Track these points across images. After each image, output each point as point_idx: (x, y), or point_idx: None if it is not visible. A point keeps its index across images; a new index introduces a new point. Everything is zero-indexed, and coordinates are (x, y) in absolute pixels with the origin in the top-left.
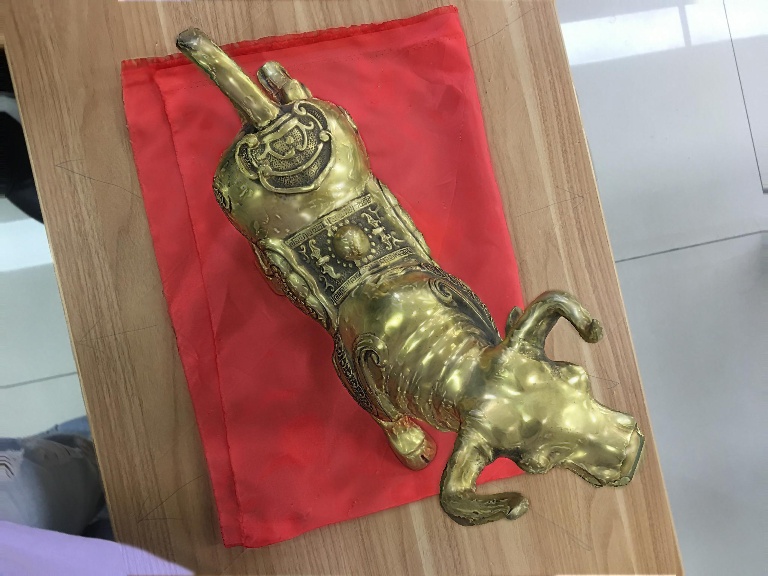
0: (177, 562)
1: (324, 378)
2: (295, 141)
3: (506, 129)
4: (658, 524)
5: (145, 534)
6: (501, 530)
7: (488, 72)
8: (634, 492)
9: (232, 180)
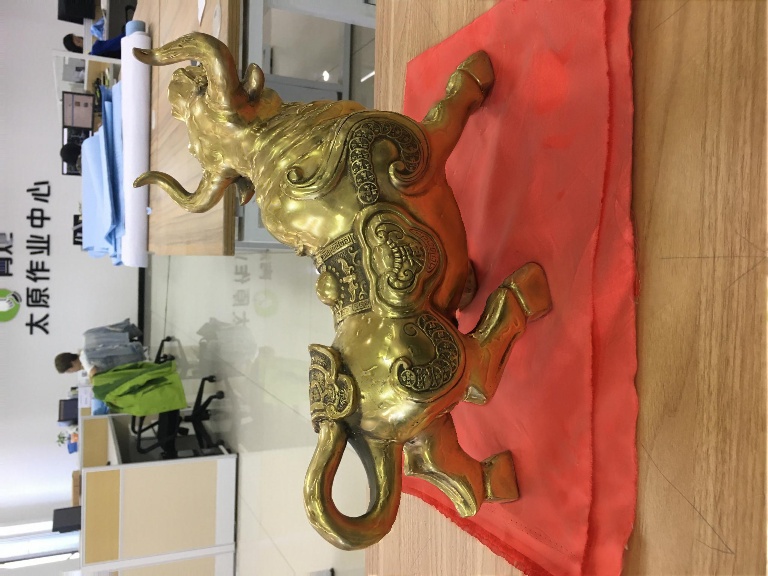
0: None
1: (525, 159)
2: None
3: None
4: (381, 13)
5: None
6: None
7: None
8: (386, 39)
9: (377, 386)
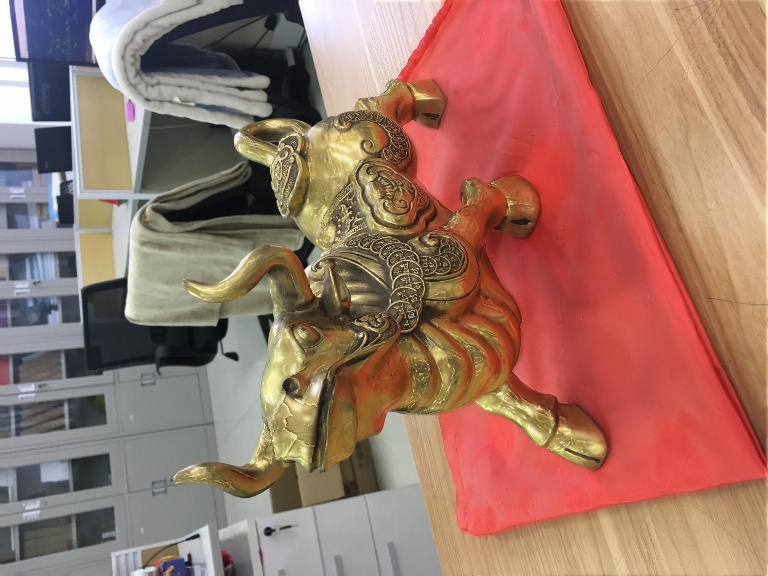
0: (456, 539)
1: None
2: (277, 174)
3: None
4: None
5: (438, 509)
6: None
7: None
8: None
9: None
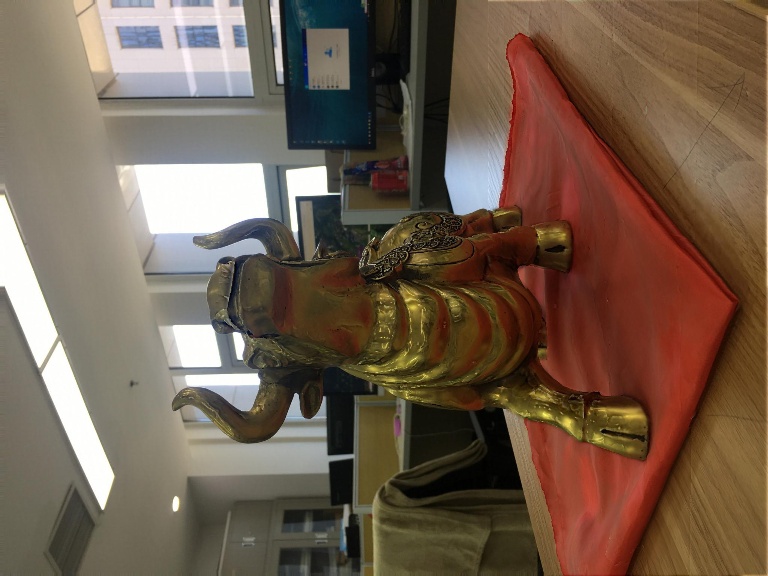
0: None
1: None
2: None
3: (566, 39)
4: None
5: None
6: (750, 494)
7: (548, 27)
8: None
9: None
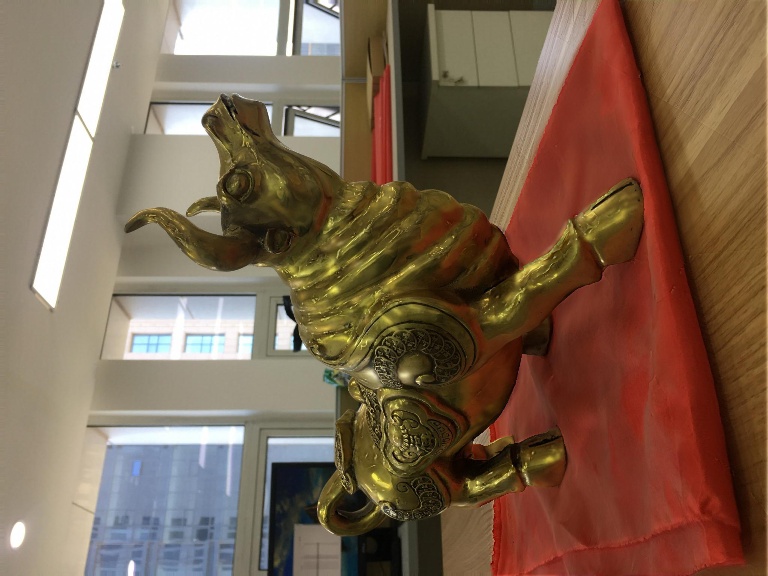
0: None
1: (602, 384)
2: None
3: None
4: None
5: None
6: None
7: None
8: None
9: None
